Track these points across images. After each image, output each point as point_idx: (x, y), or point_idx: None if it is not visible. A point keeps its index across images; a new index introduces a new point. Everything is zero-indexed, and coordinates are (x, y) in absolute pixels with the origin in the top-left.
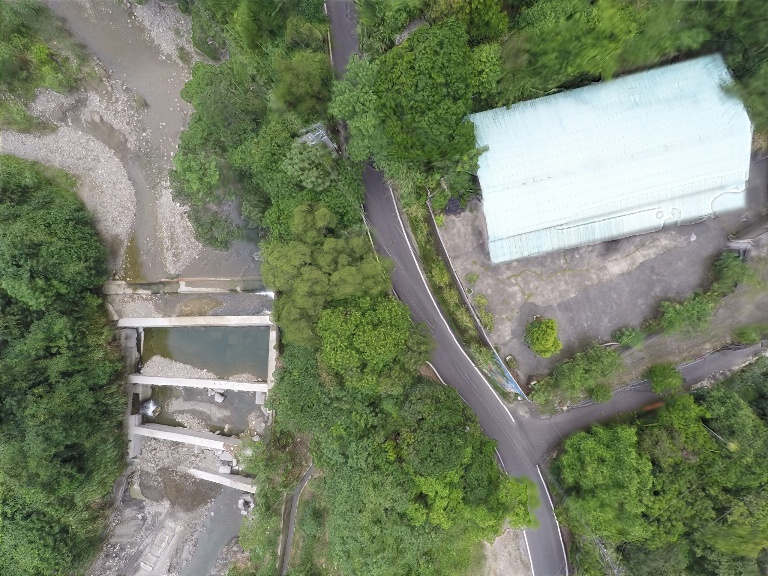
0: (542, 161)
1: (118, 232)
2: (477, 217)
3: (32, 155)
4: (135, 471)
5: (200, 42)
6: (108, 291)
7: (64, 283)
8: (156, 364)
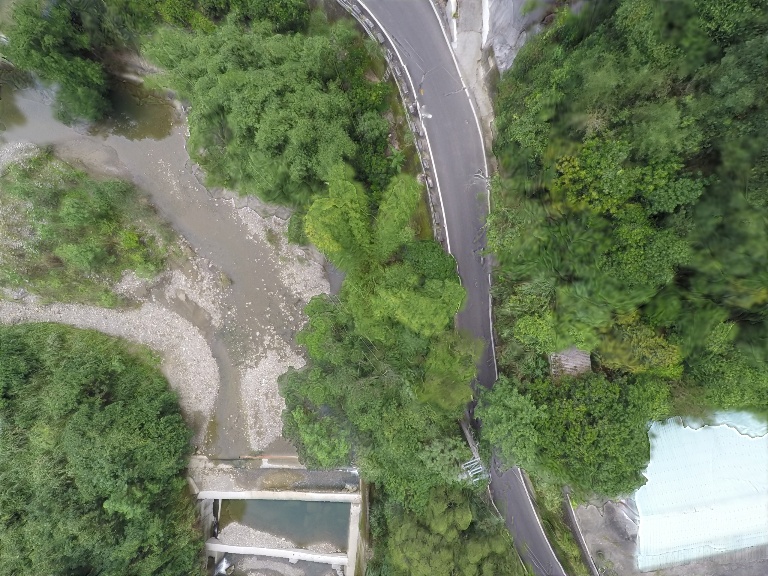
0: (702, 487)
1: (201, 409)
2: None
3: (114, 329)
4: None
5: (295, 237)
6: (189, 465)
7: (156, 482)
8: (234, 532)
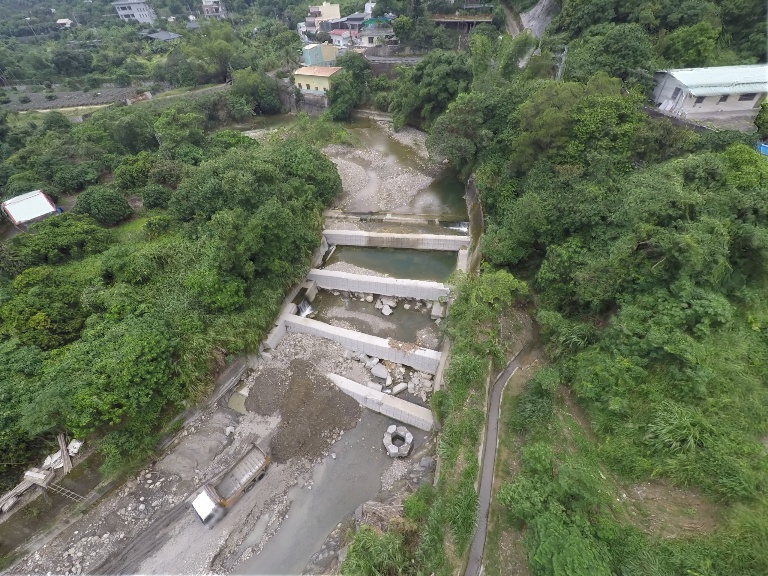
0: None
1: (349, 190)
2: (664, 113)
3: None
4: (254, 371)
5: None
6: (325, 214)
7: None
8: None
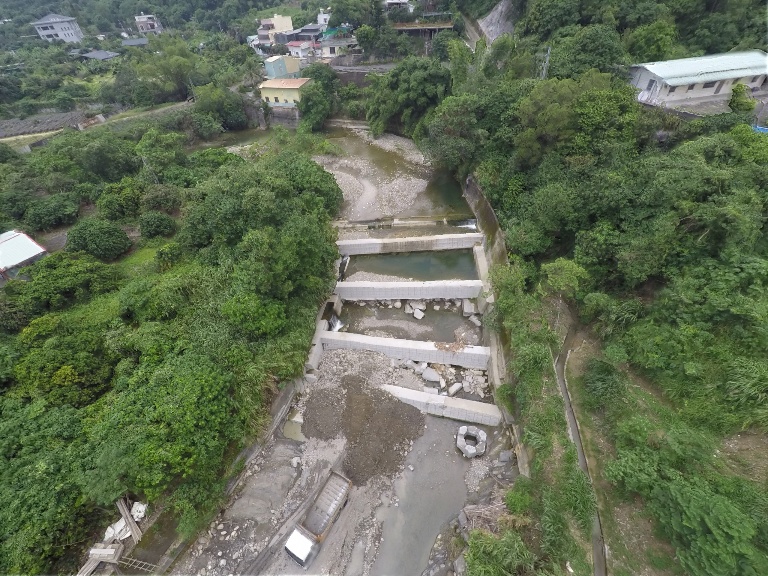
0: None
1: (348, 199)
2: None
3: None
4: (302, 395)
5: (417, 136)
6: None
7: None
8: (360, 275)
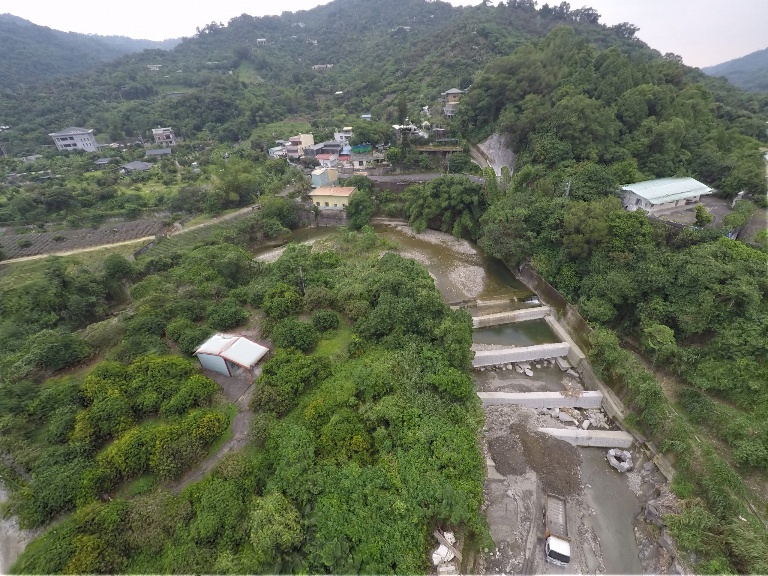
0: None
1: None
2: None
3: None
4: (482, 445)
5: (456, 232)
6: None
7: None
8: None
